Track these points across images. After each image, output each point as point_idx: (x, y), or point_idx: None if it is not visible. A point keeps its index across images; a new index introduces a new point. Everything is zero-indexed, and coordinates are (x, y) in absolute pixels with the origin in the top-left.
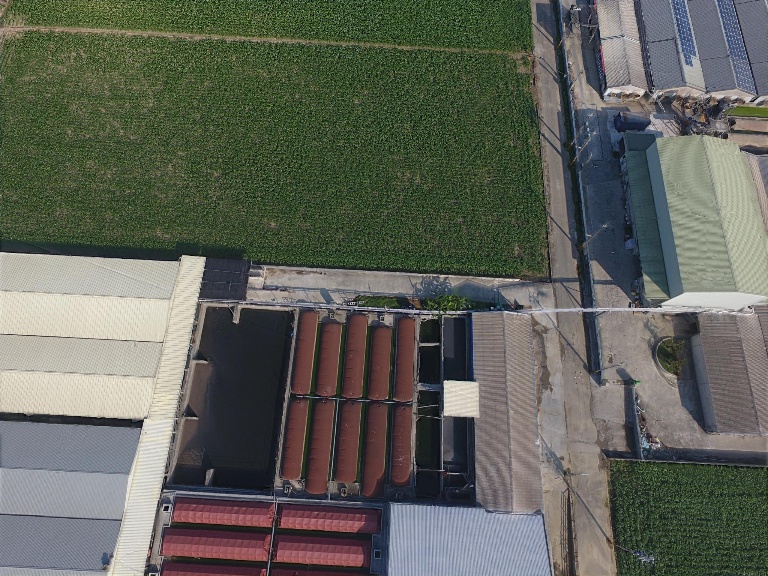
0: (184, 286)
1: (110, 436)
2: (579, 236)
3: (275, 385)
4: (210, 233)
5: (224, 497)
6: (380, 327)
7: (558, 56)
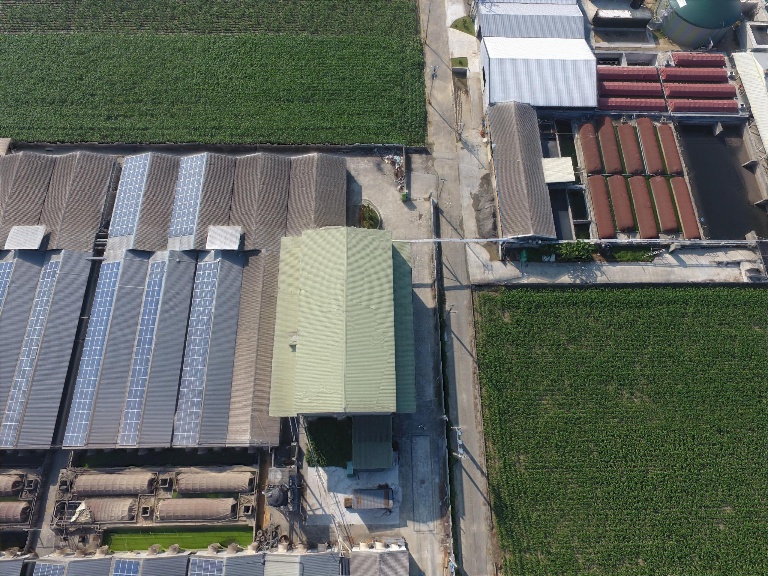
0: None
1: None
2: (443, 336)
3: (694, 190)
4: None
5: (706, 114)
6: (631, 228)
7: None
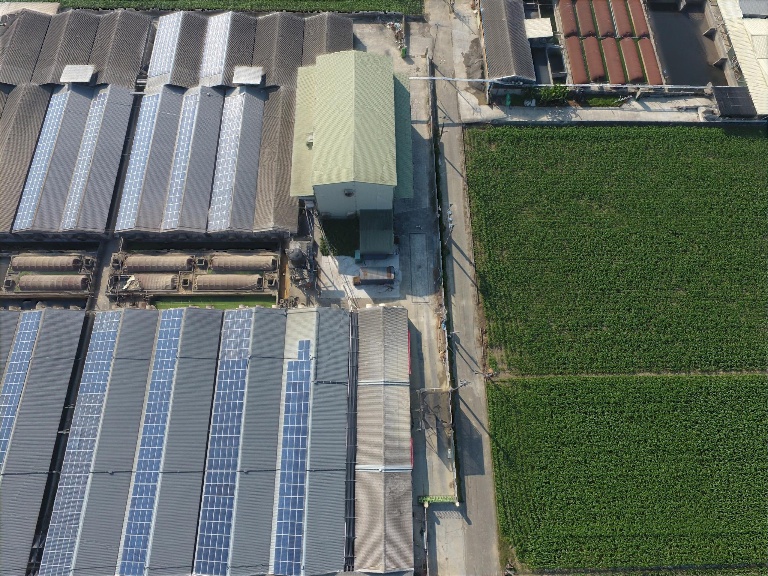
0: (763, 92)
1: (759, 9)
2: (437, 161)
3: (660, 53)
4: (761, 147)
5: None
6: (602, 77)
7: (454, 377)
